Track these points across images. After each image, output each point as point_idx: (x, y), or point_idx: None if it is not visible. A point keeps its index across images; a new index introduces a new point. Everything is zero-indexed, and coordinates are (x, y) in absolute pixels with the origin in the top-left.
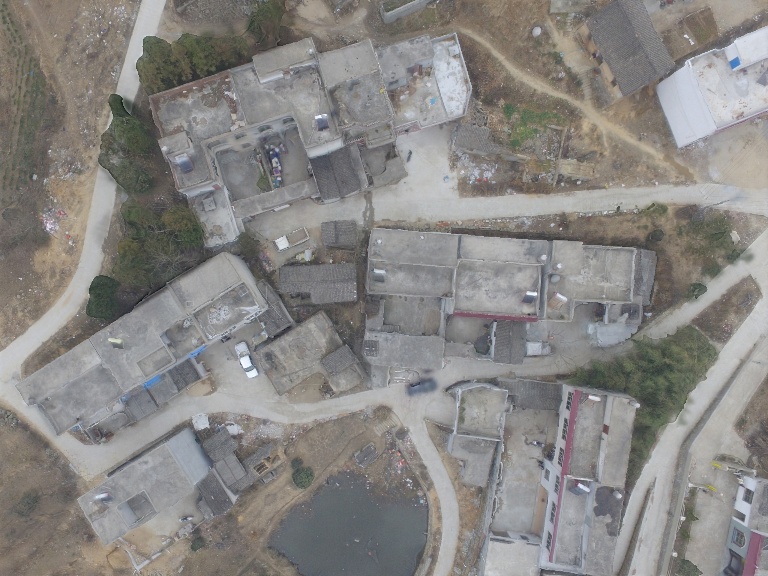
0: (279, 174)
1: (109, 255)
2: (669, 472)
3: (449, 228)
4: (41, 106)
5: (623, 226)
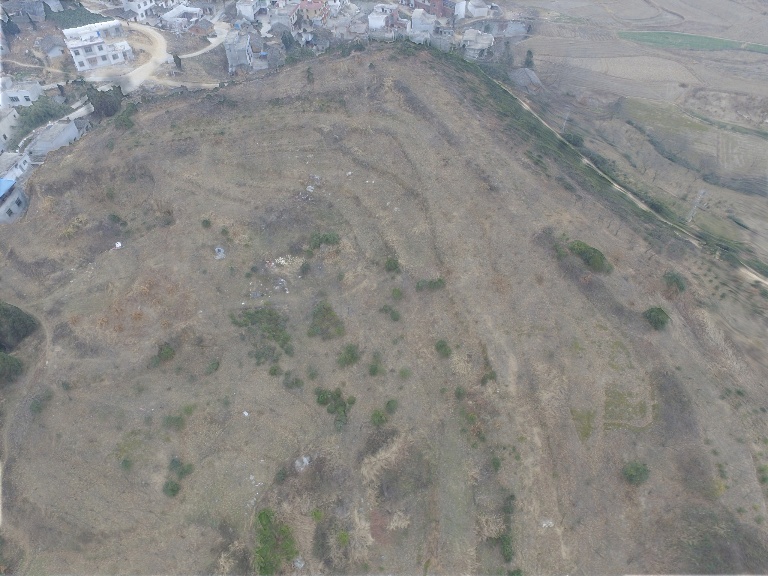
0: None
1: None
2: None
3: None
4: None
5: (53, 93)
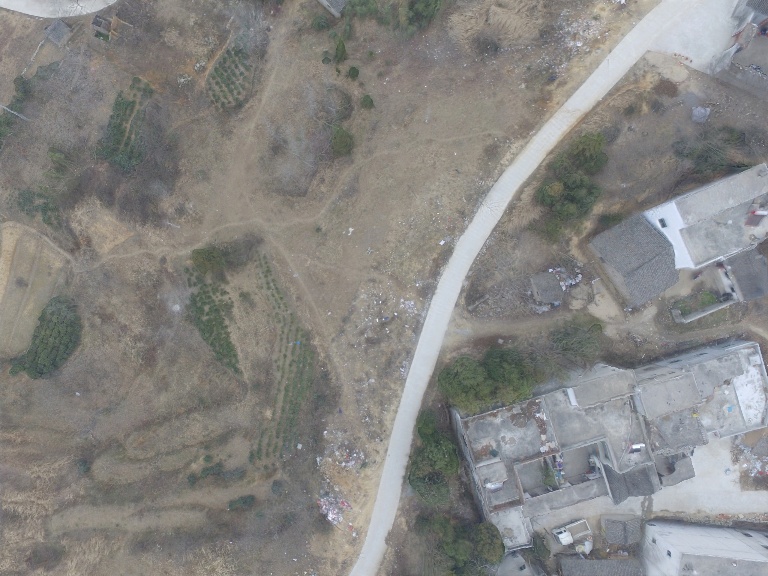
0: (562, 467)
1: (392, 548)
2: None
3: (730, 522)
4: (309, 377)
5: None
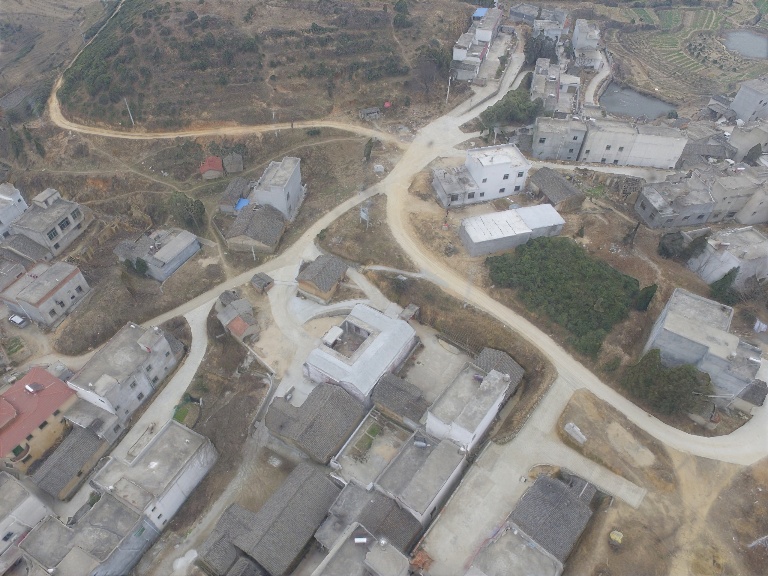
0: None
1: None
2: (503, 89)
3: (629, 165)
4: None
5: None
